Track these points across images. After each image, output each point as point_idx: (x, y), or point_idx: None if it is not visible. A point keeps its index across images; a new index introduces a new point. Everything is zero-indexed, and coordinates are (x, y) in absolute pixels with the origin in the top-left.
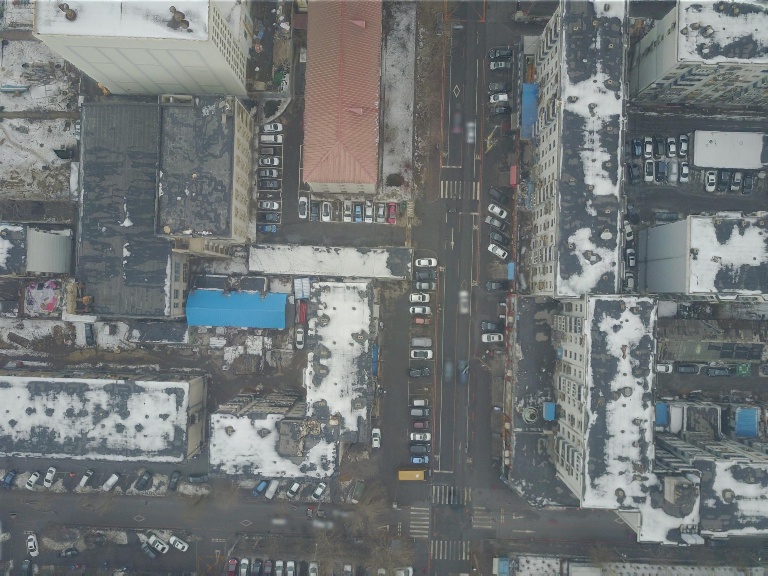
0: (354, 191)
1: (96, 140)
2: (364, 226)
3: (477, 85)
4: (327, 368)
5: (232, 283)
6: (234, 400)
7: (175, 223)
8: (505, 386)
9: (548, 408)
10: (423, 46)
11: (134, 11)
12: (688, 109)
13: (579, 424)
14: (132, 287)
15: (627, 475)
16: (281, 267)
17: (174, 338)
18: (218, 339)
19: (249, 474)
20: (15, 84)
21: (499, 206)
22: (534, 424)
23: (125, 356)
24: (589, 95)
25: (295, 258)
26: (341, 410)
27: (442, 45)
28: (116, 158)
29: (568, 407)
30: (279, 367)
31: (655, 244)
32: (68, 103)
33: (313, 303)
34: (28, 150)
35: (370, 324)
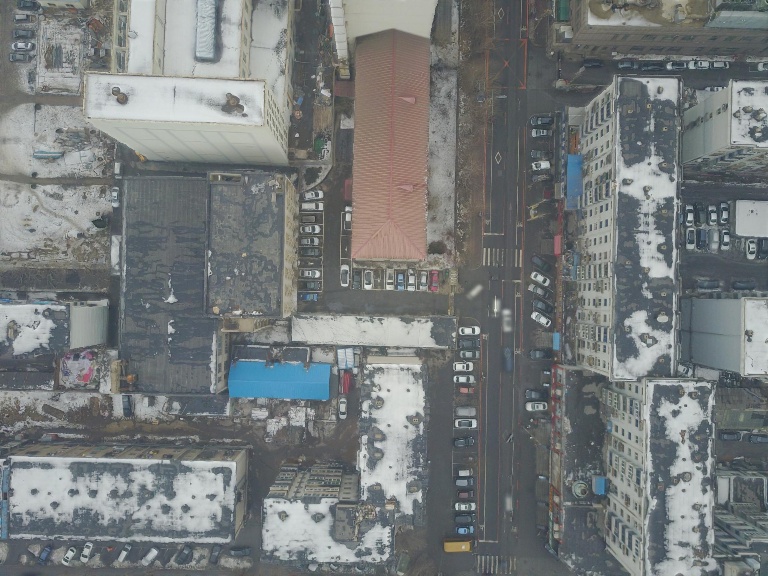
0: (397, 260)
1: (139, 214)
2: (406, 294)
3: (519, 152)
4: (381, 451)
5: (274, 354)
6: (281, 478)
7: (224, 303)
8: (551, 457)
9: (598, 482)
10: (464, 113)
11: (188, 95)
12: (728, 177)
13: (636, 506)
14: (177, 365)
15: (687, 560)
16: (324, 337)
17: (215, 410)
18: (260, 411)
19: (303, 560)
20: (48, 150)
21: (542, 274)
22: (583, 498)
23: (164, 427)
24: (644, 178)
25: (338, 328)
26: (396, 493)
27: None
28: (160, 233)
29: (621, 484)
30: (321, 437)
31: (701, 316)
32: (103, 169)
33: (367, 385)
34: (62, 217)
35: (425, 406)
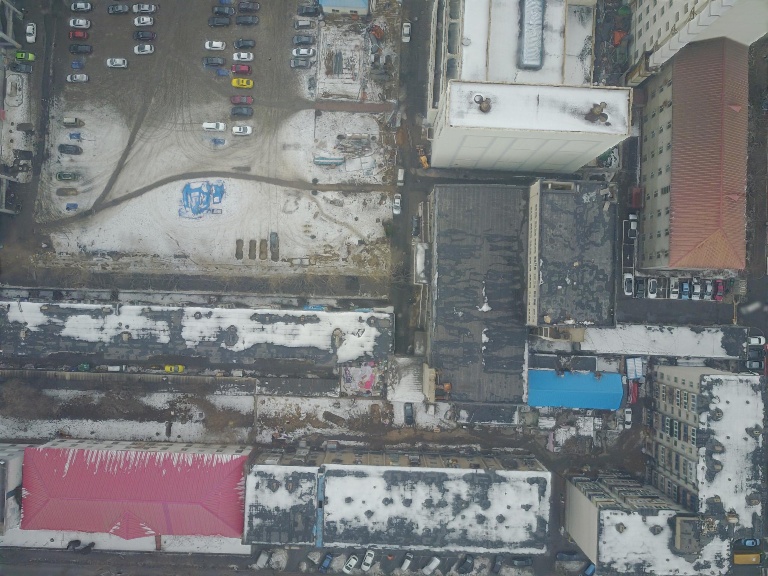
0: (687, 269)
1: (451, 222)
2: (689, 303)
3: None
4: (720, 463)
5: (563, 363)
6: (590, 488)
7: (555, 312)
8: None
9: None
10: (748, 121)
11: (551, 103)
12: None
13: None
14: (491, 374)
15: None
16: (614, 346)
17: (503, 419)
18: (548, 420)
19: (641, 572)
20: (329, 156)
21: None
22: None
23: (445, 435)
24: None
25: (628, 337)
26: (735, 506)
27: (766, 120)
28: (474, 241)
29: None
30: (604, 447)
31: None
32: (384, 176)
33: (705, 396)
34: (342, 224)
35: (764, 418)
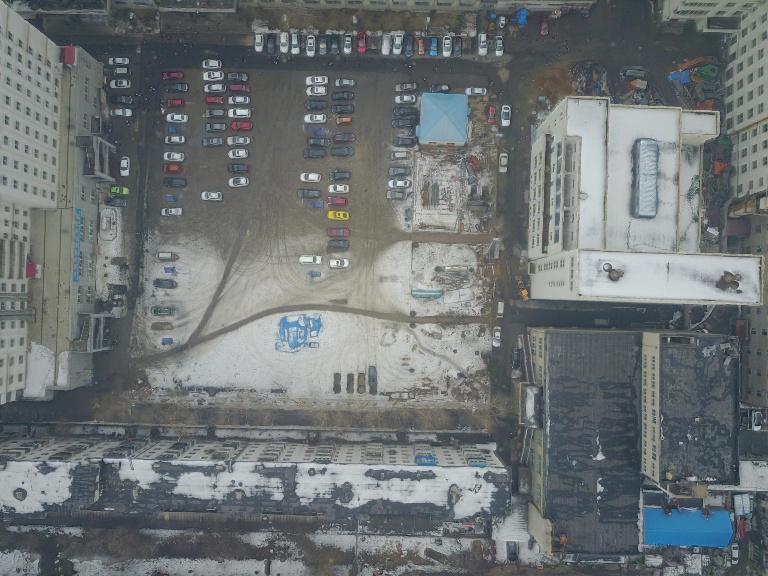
0: None
1: (563, 369)
2: None
3: None
4: None
5: (669, 499)
6: None
7: (677, 469)
8: None
9: None
10: None
11: (681, 271)
12: None
13: None
14: (606, 524)
15: None
16: None
17: (610, 557)
18: (654, 557)
19: None
20: (427, 288)
21: None
22: None
23: (548, 572)
24: None
25: None
26: None
27: None
28: (586, 389)
29: None
30: None
31: None
32: (482, 308)
33: None
34: (441, 356)
35: None
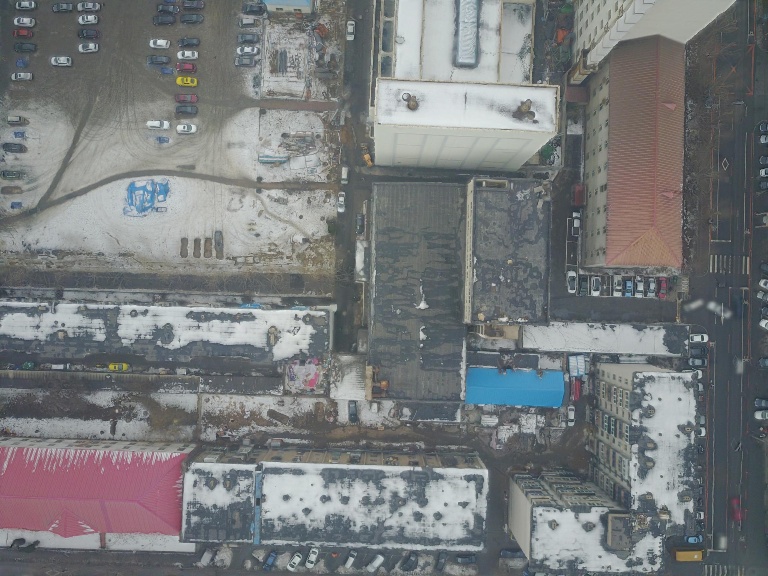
0: (629, 267)
1: (389, 220)
2: (633, 301)
3: (746, 158)
4: (652, 460)
5: (505, 360)
6: (529, 485)
7: (489, 310)
8: None
9: None
10: (691, 118)
11: (479, 101)
12: None
13: None
14: (429, 371)
15: None
16: (556, 344)
17: (446, 416)
18: (490, 417)
19: (573, 569)
20: (273, 154)
21: None
22: None
23: (389, 433)
24: None
25: (570, 335)
26: (667, 503)
27: (710, 118)
28: (411, 239)
29: None
30: (548, 444)
31: None
32: (328, 174)
33: (637, 393)
34: (287, 222)
35: (696, 415)
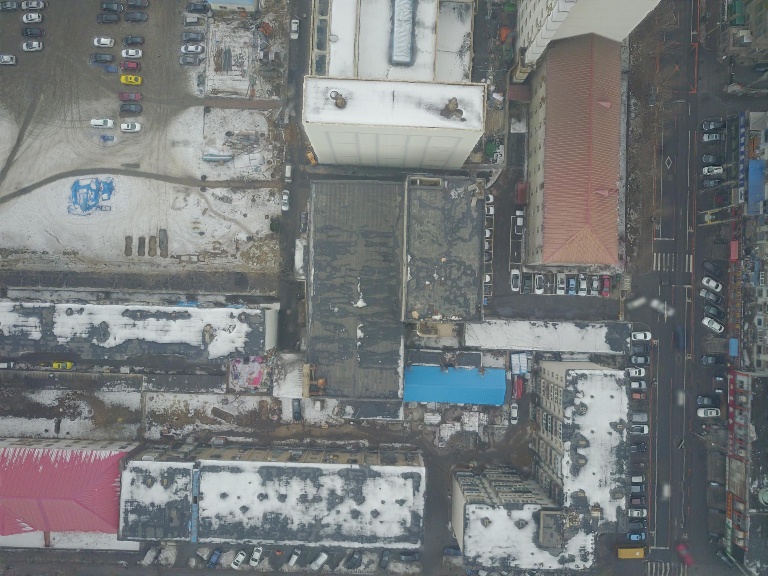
0: (571, 265)
1: (327, 218)
2: (576, 299)
3: (689, 156)
4: (585, 457)
5: (448, 358)
6: (467, 483)
7: (423, 308)
8: (729, 463)
9: None
10: (635, 117)
11: (406, 99)
12: None
13: None
14: (366, 369)
15: None
16: (498, 342)
17: (389, 414)
18: (433, 415)
19: (506, 566)
20: (218, 153)
21: (714, 279)
22: None
23: (333, 431)
24: None
25: (512, 333)
26: (600, 500)
27: (653, 116)
28: (349, 237)
29: None
30: (491, 442)
31: None
32: (273, 172)
33: (570, 391)
34: (231, 220)
35: (628, 412)
